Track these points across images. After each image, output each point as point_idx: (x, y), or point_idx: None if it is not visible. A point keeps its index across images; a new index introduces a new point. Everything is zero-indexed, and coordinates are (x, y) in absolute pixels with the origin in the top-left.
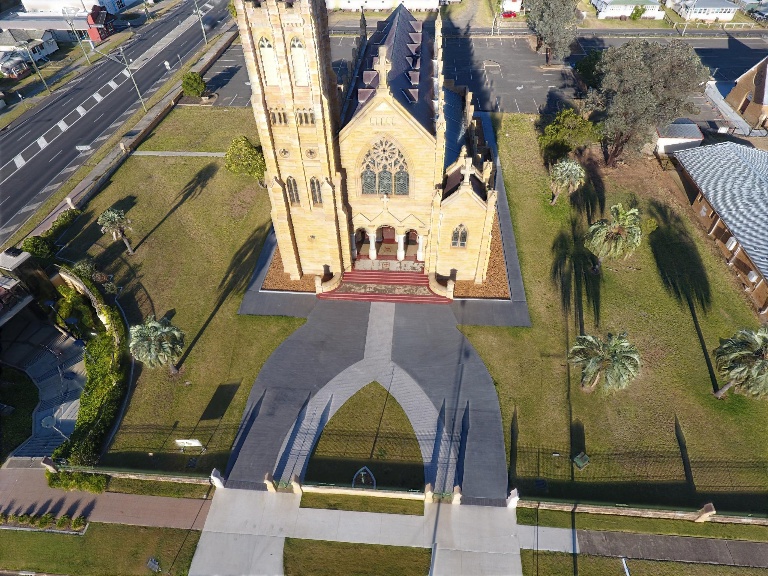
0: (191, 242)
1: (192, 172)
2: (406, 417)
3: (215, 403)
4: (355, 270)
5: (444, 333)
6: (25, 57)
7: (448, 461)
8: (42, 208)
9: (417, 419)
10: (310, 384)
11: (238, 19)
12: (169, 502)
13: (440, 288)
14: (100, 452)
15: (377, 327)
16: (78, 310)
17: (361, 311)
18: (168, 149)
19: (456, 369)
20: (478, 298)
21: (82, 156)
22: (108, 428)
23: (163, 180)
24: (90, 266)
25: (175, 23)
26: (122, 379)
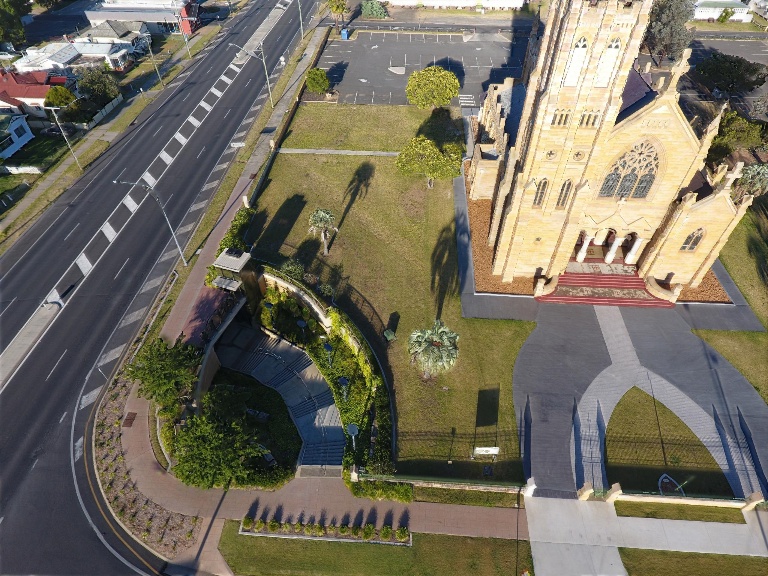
0: (381, 243)
1: (349, 171)
2: (683, 423)
3: (483, 409)
4: (567, 273)
5: (682, 337)
6: (145, 50)
7: (746, 468)
8: (211, 206)
9: (695, 425)
10: (570, 389)
11: (571, 18)
12: (483, 511)
13: (665, 292)
14: (392, 460)
15: (611, 331)
16: (286, 312)
17: (587, 315)
18: (314, 147)
19: (711, 374)
20: (700, 302)
21: (228, 153)
22: (390, 435)
23: (323, 179)
24: (301, 267)
25: (260, 17)
26: (382, 384)
